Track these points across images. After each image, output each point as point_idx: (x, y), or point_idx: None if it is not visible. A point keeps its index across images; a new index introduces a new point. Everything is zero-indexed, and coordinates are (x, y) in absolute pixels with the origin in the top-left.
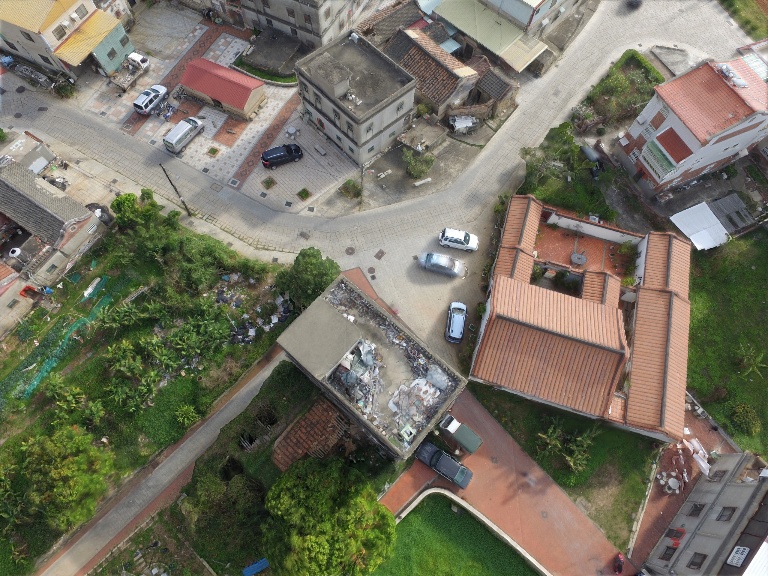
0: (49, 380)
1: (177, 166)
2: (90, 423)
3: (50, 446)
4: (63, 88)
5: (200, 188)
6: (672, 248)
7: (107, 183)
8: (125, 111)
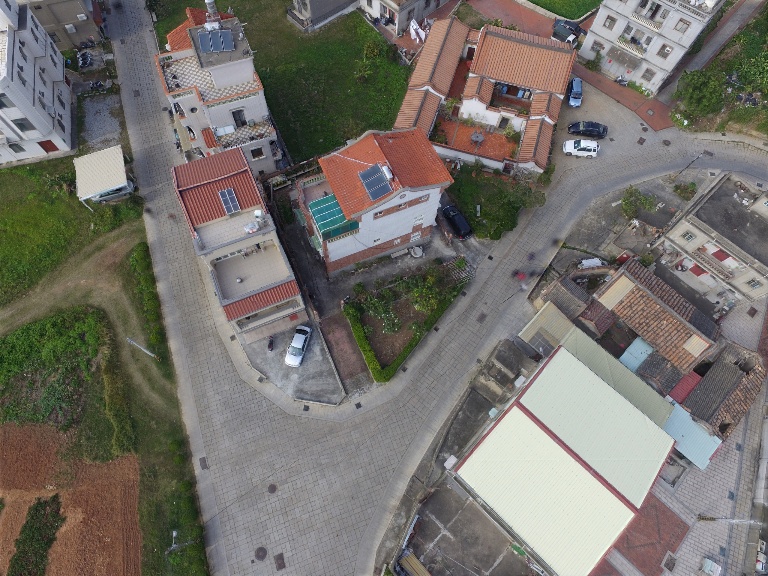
0: None
1: None
2: None
3: None
4: None
5: None
6: None
7: None
8: None
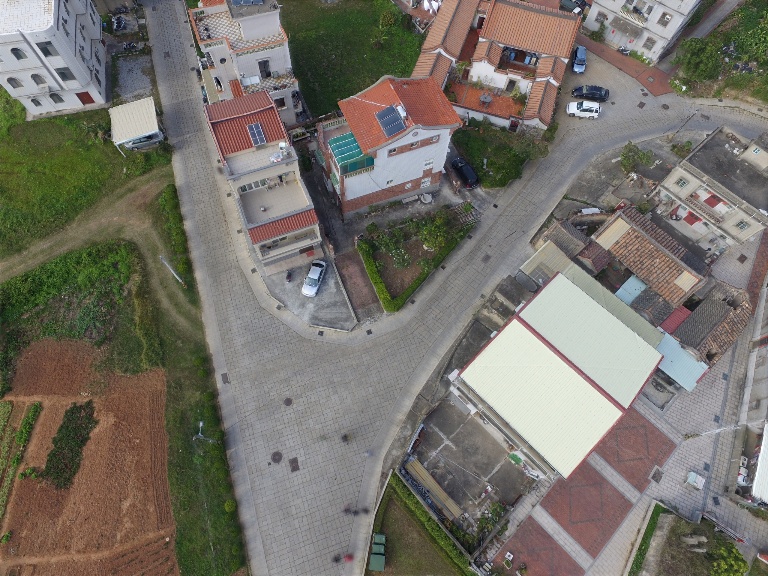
0: None
1: None
2: None
3: None
4: None
5: None
6: None
7: None
8: None
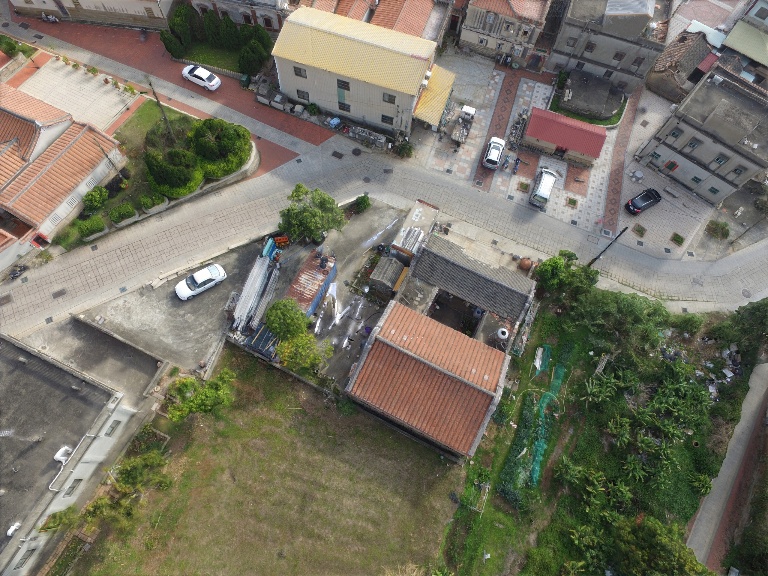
0: (562, 465)
1: (545, 221)
2: (620, 506)
3: (666, 541)
4: (405, 148)
5: (578, 242)
6: None
7: (491, 245)
8: (469, 167)
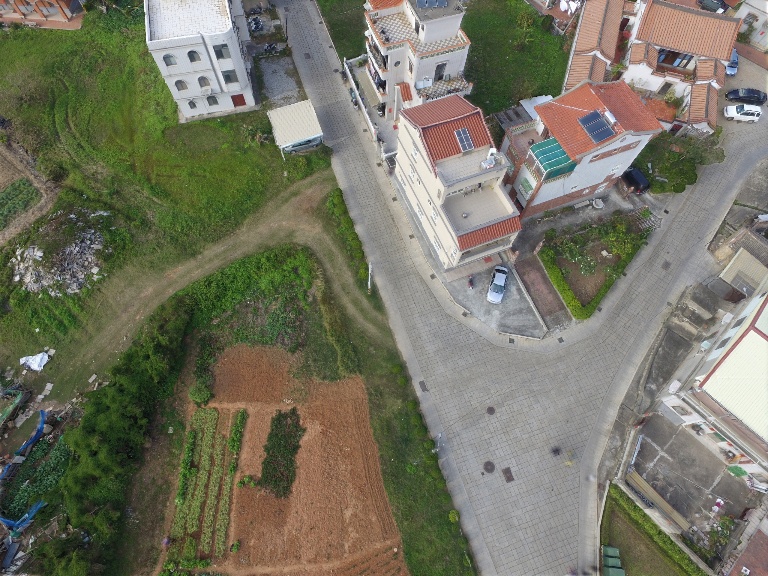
0: None
1: None
2: None
3: None
4: None
5: None
6: None
7: None
8: None
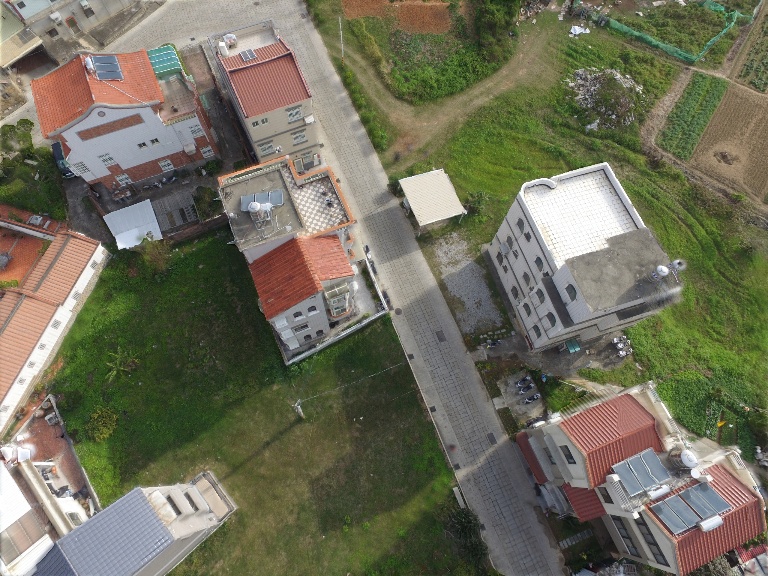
0: None
1: None
2: None
3: None
4: None
5: None
6: (66, 248)
7: None
8: None
